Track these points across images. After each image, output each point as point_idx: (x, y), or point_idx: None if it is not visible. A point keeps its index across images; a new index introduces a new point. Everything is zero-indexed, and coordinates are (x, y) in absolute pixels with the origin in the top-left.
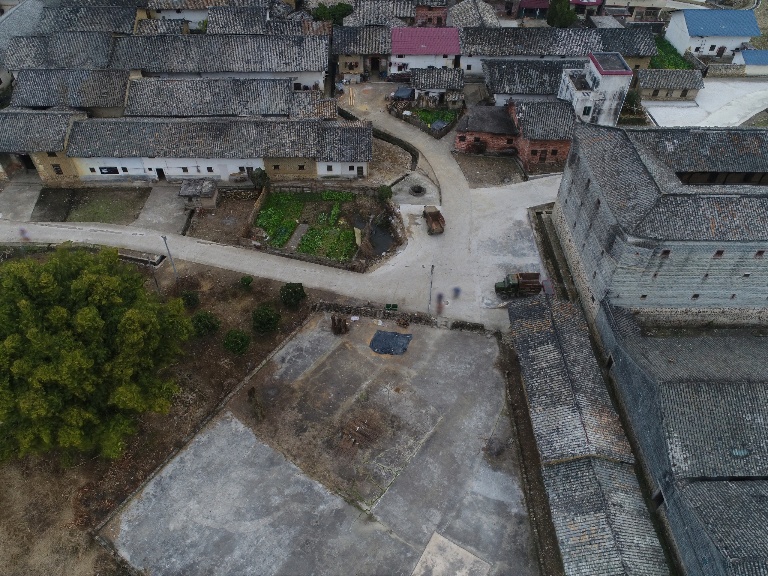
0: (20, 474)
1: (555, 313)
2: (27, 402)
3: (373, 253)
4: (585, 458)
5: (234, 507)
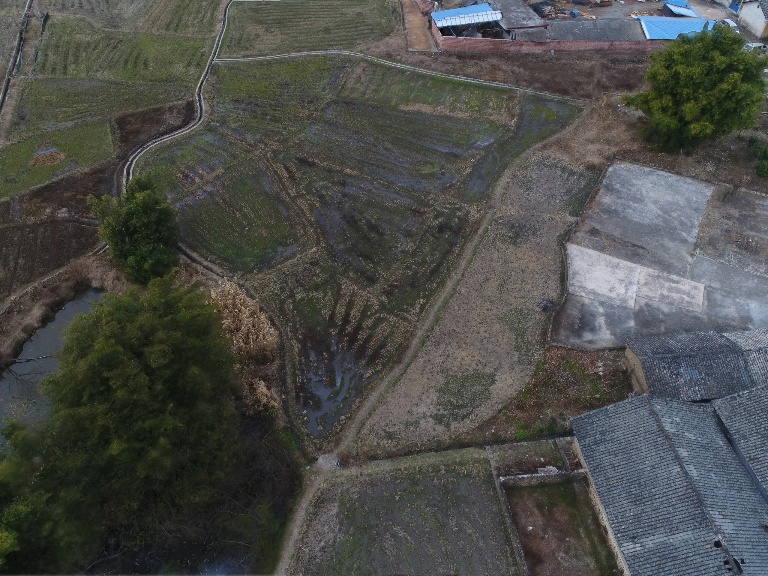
0: (624, 129)
1: None
2: (663, 70)
3: None
4: None
5: (659, 199)
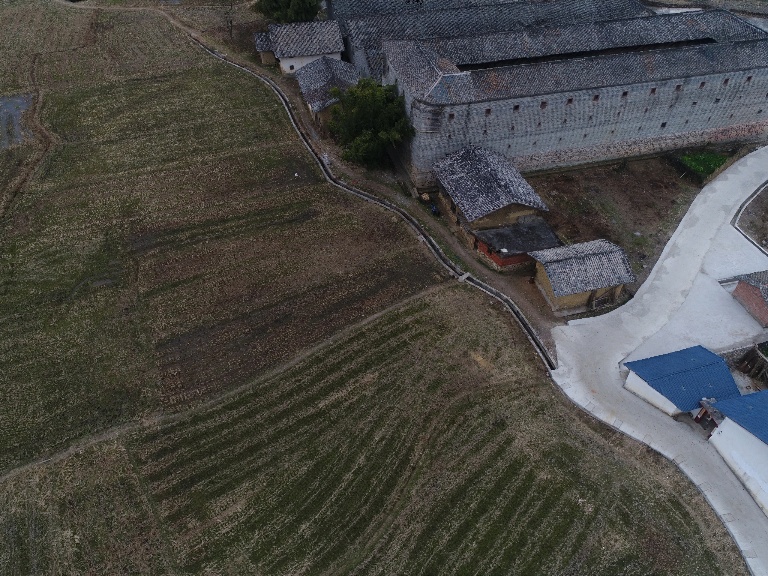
0: None
1: None
2: None
3: None
4: None
5: None
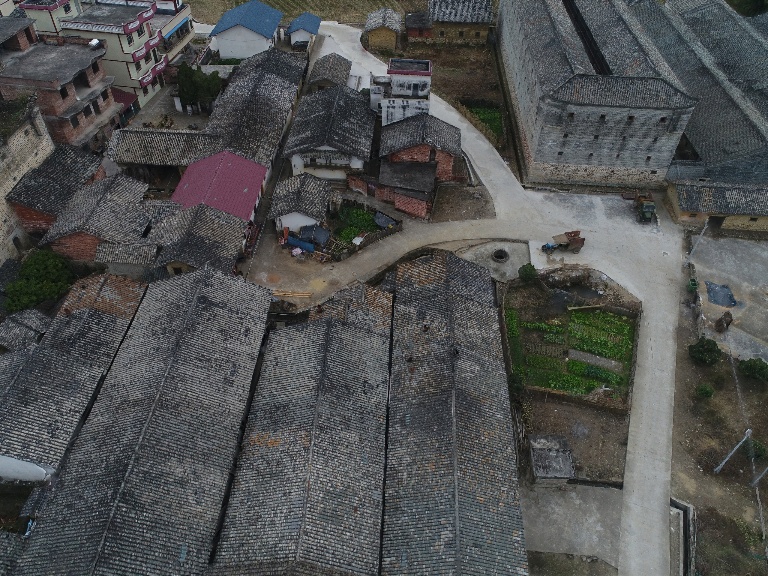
0: None
1: None
2: None
3: None
4: None
5: None
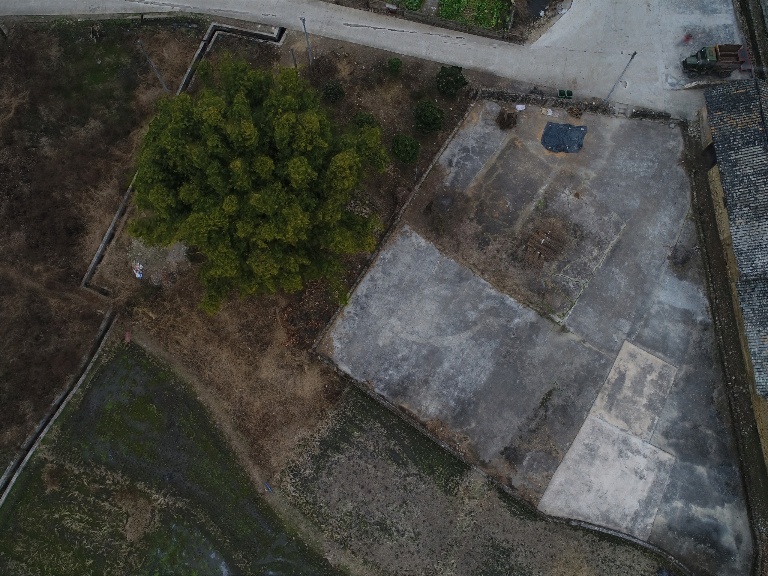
0: None
1: (764, 105)
2: (260, 265)
3: (529, 13)
4: None
5: (434, 323)
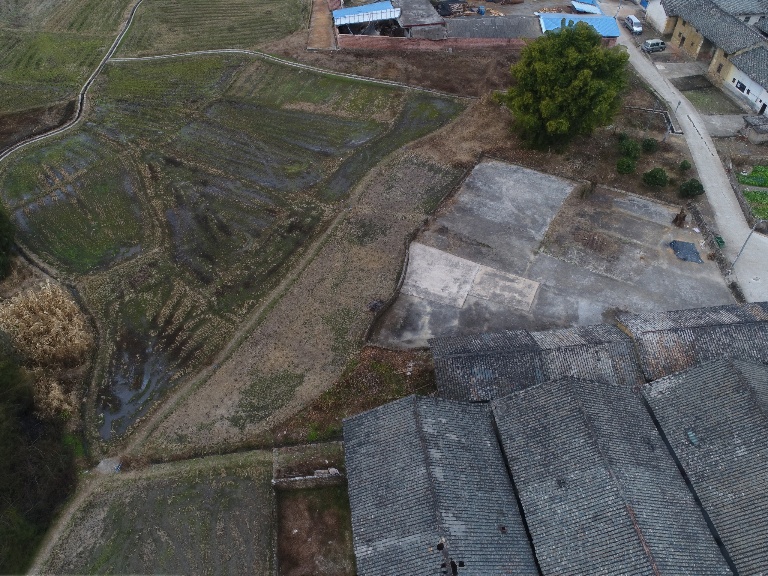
0: (502, 127)
1: None
2: (521, 67)
3: None
4: (630, 337)
5: (517, 197)
